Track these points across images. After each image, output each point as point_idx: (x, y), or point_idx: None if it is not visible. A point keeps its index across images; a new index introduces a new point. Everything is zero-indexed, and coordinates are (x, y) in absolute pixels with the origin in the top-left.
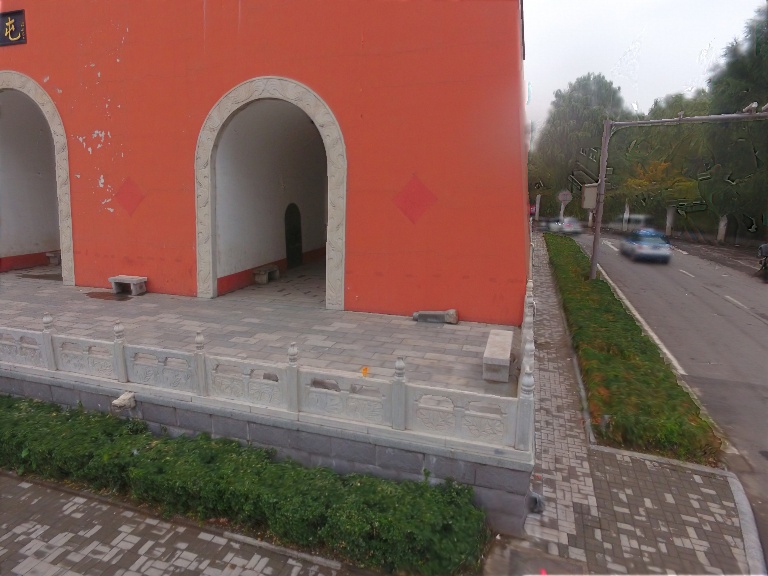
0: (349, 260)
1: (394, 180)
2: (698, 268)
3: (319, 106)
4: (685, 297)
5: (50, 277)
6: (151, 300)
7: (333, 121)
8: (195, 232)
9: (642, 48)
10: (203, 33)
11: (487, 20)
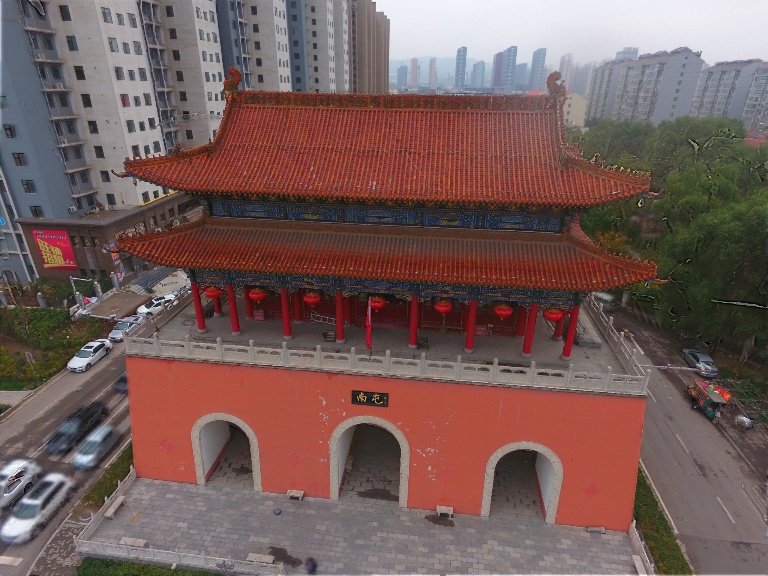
0: (559, 507)
1: (583, 483)
2: (655, 385)
3: (553, 456)
4: (660, 440)
5: (377, 495)
6: (465, 523)
7: (559, 461)
8: (483, 492)
9: (606, 136)
10: (497, 421)
11: (629, 437)
